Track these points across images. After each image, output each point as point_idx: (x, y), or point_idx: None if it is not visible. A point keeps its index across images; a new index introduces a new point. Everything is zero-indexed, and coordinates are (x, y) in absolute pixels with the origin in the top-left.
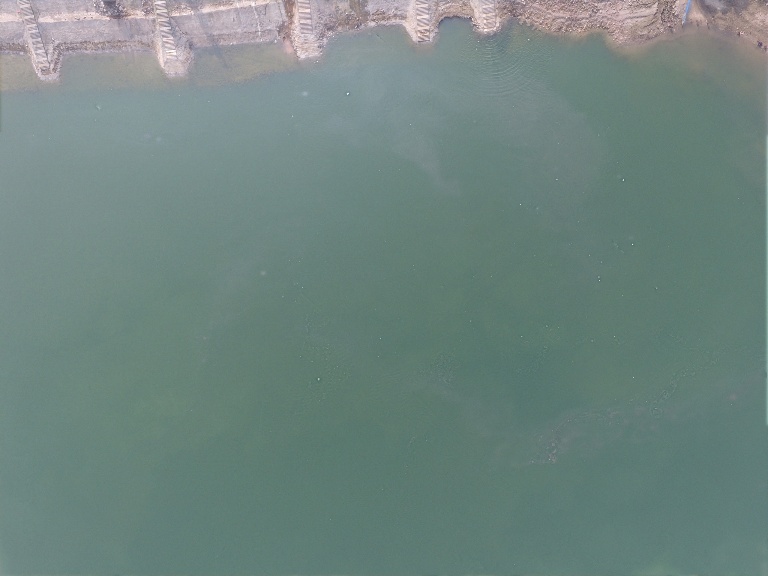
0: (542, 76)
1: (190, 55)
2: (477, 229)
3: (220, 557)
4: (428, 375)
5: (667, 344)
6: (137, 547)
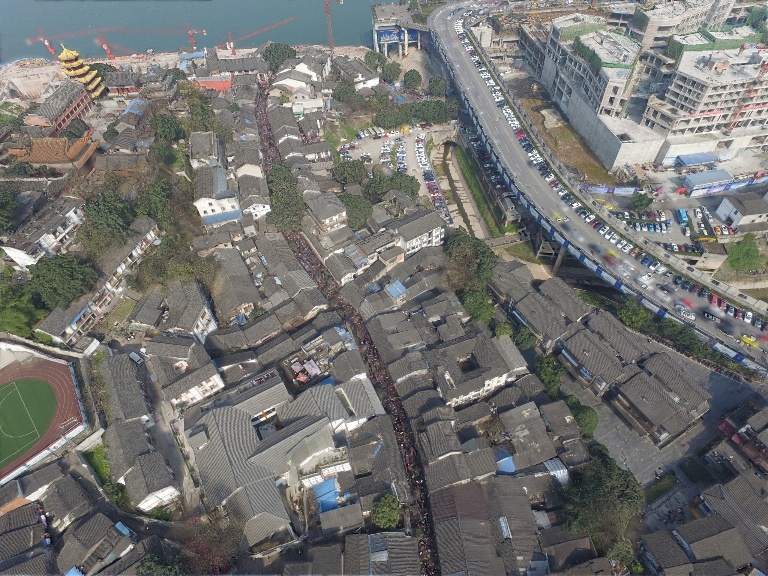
0: None
1: None
2: (120, 28)
3: None
4: (156, 7)
5: None
6: None
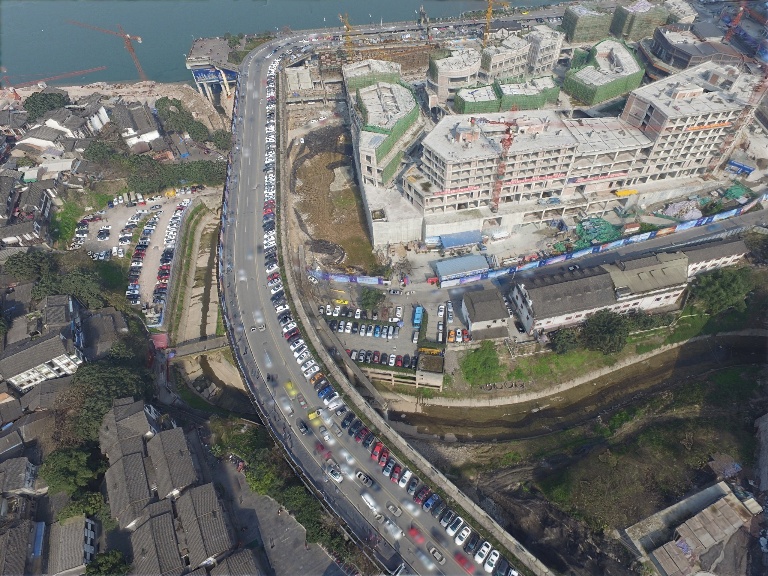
0: None
1: None
2: None
3: (112, 8)
4: (2, 34)
5: None
6: (140, 6)
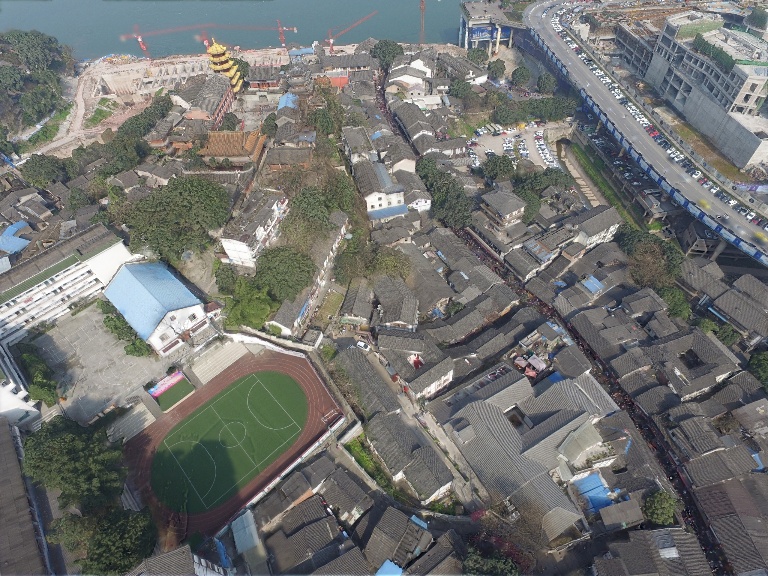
0: None
1: None
2: None
3: None
4: (226, 5)
5: None
6: None
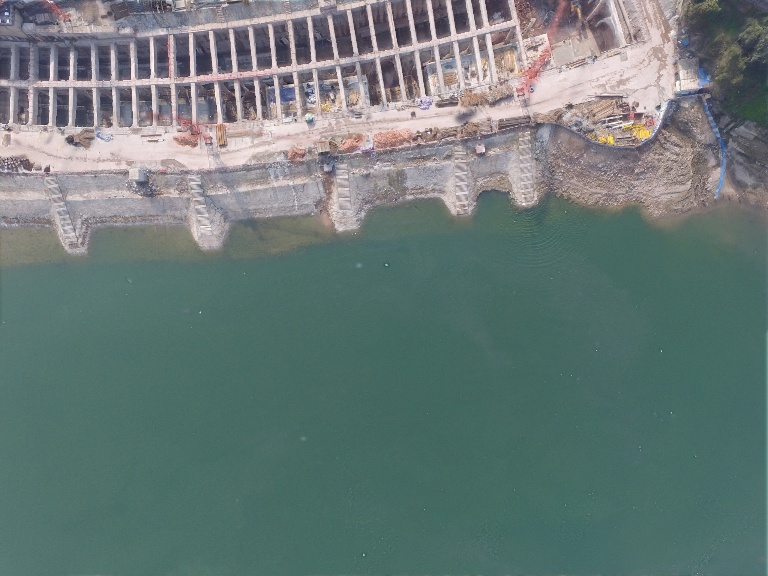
0: (580, 248)
1: (225, 228)
2: (519, 400)
3: None
4: (474, 546)
5: (706, 509)
6: None
